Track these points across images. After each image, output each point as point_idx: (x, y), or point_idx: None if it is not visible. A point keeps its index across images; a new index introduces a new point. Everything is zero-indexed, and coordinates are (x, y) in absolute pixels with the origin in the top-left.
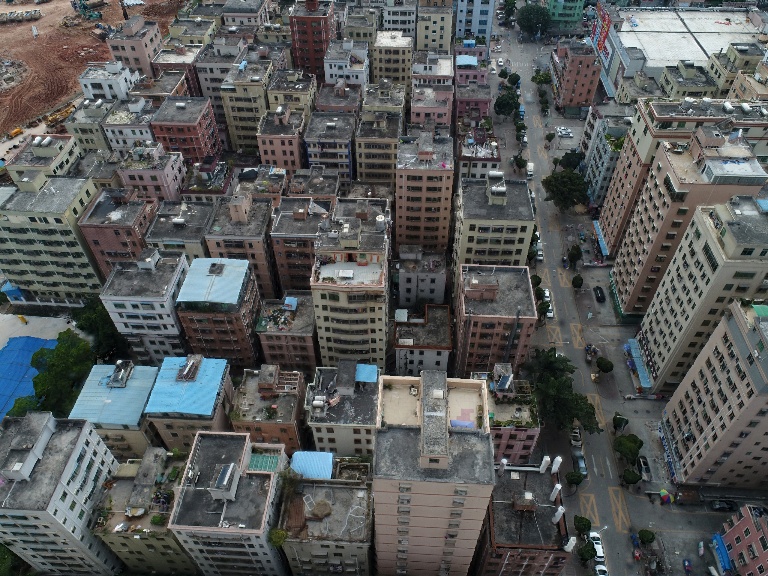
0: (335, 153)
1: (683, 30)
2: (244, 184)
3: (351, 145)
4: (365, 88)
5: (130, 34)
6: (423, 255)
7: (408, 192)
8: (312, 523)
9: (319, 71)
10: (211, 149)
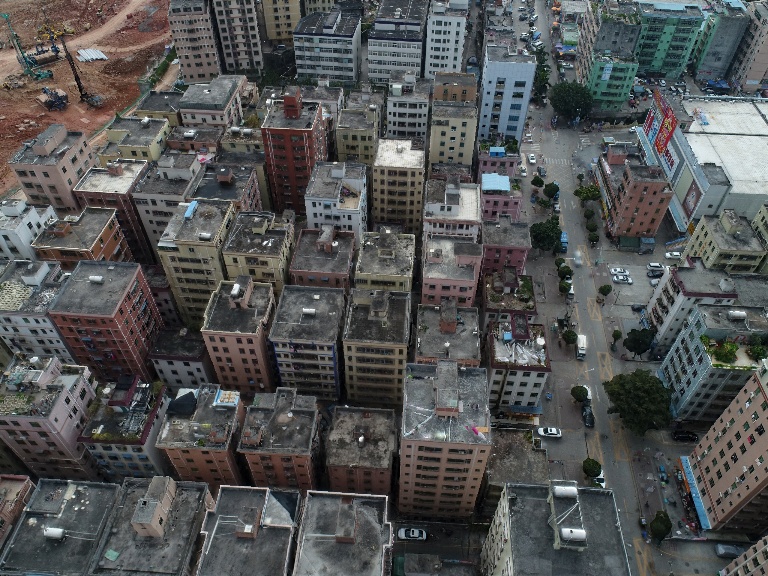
0: (314, 354)
1: (767, 132)
2: (175, 423)
3: (337, 339)
4: (361, 227)
5: (43, 154)
6: (441, 568)
7: (419, 461)
8: None
9: (302, 191)
10: (142, 331)
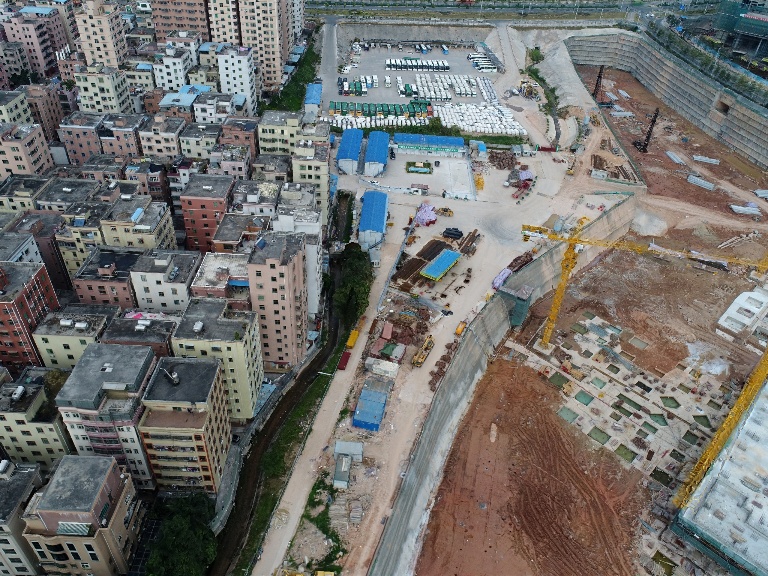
0: None
1: None
2: None
3: None
4: None
5: None
6: None
7: None
8: None
9: None
10: None
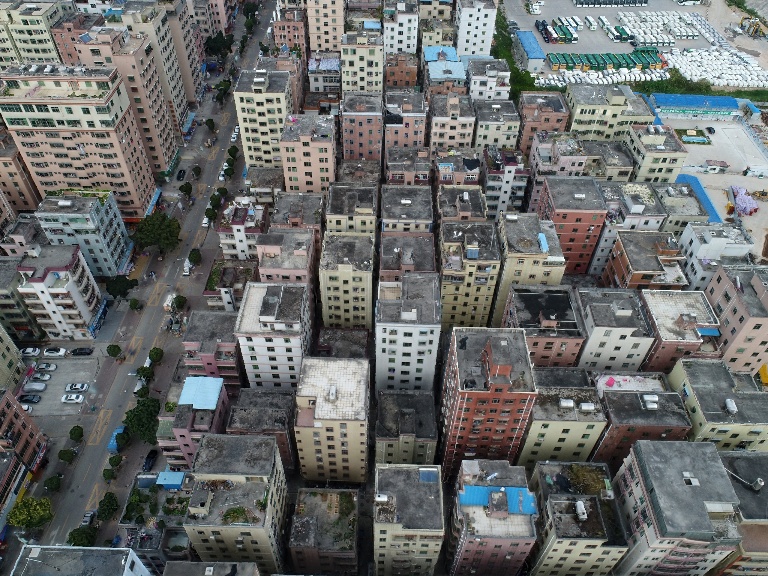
0: None
1: None
2: None
3: None
4: None
5: None
6: None
7: None
8: (369, 14)
9: None
10: None
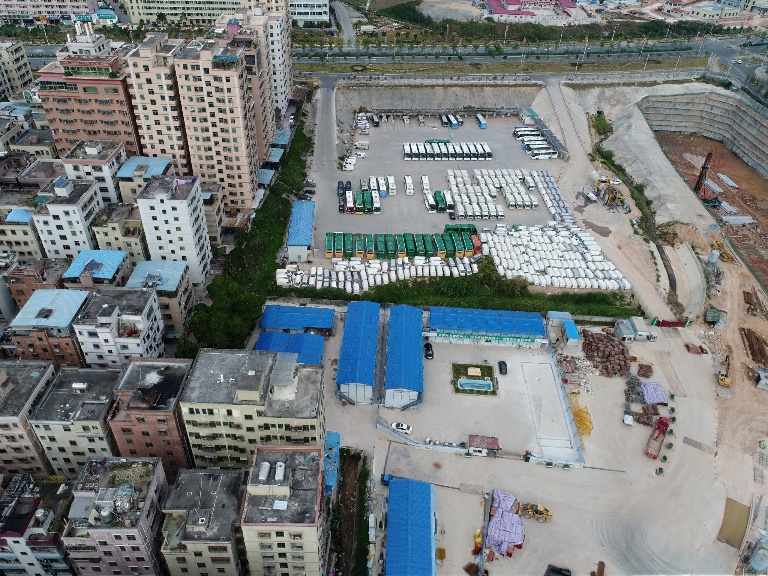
0: None
1: None
2: None
3: None
4: None
5: None
6: None
7: None
8: None
9: None
10: None
